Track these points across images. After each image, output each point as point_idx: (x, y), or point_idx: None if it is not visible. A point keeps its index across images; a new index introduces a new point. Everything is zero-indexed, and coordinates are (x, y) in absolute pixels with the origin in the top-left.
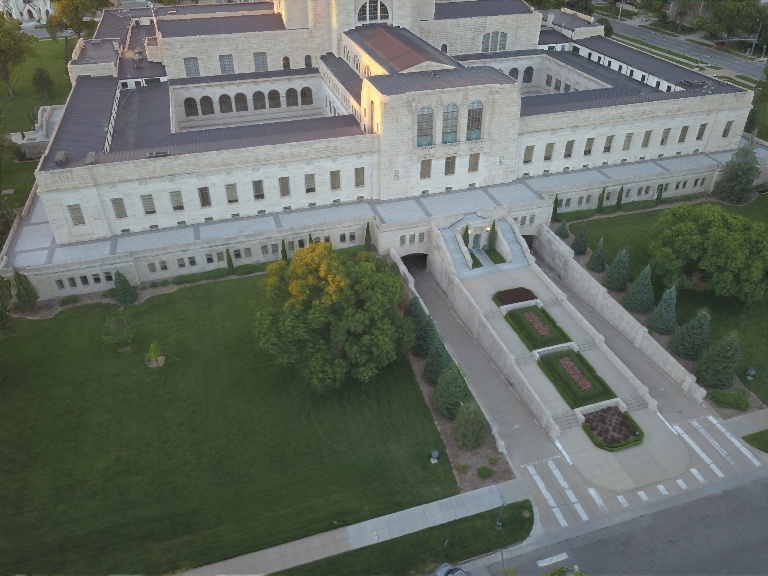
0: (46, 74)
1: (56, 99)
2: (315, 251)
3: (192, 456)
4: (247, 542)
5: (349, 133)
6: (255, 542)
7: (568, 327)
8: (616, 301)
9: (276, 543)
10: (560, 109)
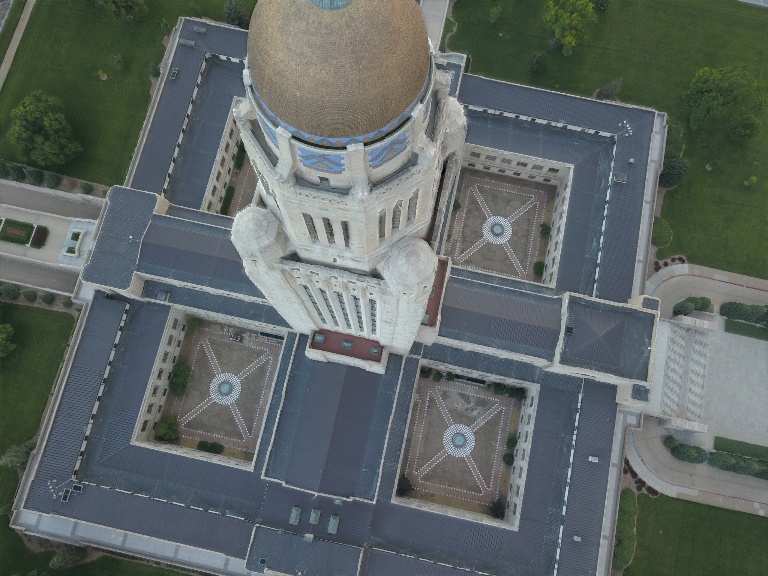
0: (535, 60)
1: (525, 74)
2: (37, 112)
3: (47, 78)
4: (6, 86)
5: (147, 182)
6: (4, 88)
7: (8, 246)
8: (3, 281)
9: (0, 93)
10: (98, 339)
